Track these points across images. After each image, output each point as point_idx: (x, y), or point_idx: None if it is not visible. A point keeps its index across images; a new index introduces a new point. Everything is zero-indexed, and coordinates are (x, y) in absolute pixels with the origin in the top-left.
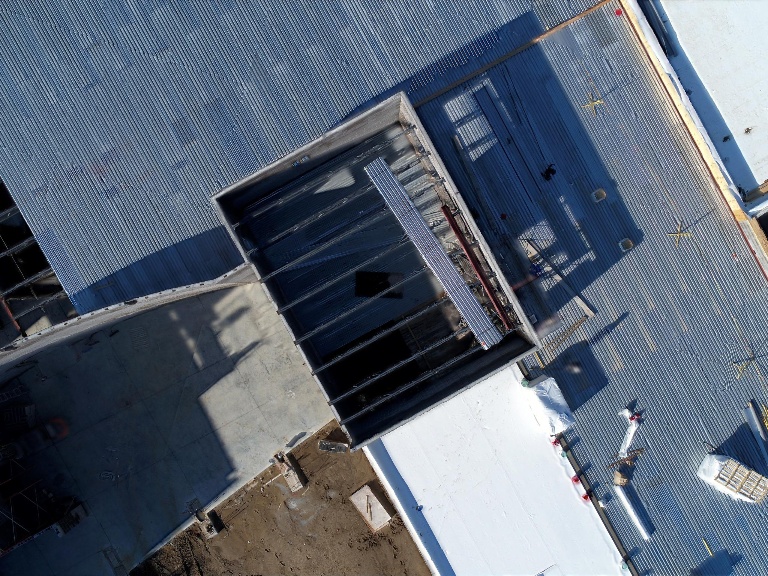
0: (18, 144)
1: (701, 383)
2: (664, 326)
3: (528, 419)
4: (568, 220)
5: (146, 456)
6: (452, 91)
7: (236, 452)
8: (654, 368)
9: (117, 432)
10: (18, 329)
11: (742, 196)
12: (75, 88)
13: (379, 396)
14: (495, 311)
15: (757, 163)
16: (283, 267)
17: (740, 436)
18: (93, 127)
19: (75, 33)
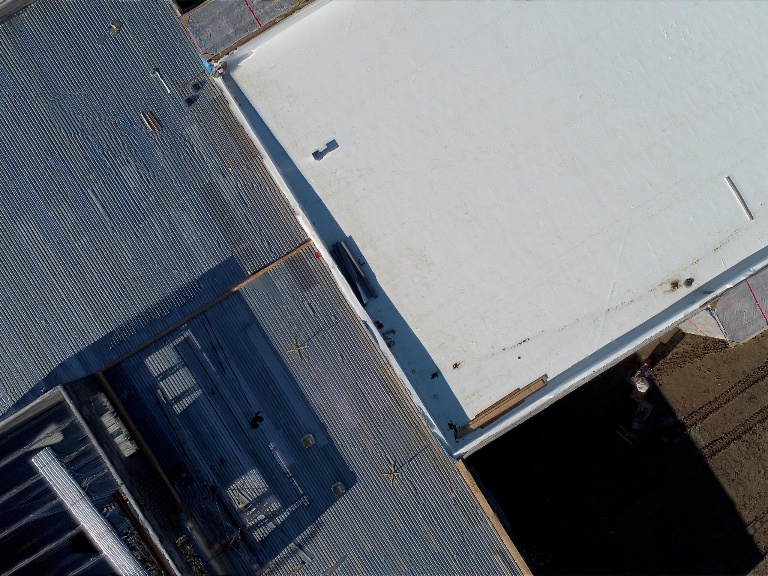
0: None
1: None
2: (383, 567)
3: None
4: (279, 467)
5: None
6: (152, 345)
7: None
8: None
9: None
10: None
11: (454, 432)
12: None
13: None
14: None
15: (467, 398)
16: None
17: None
18: None
19: None
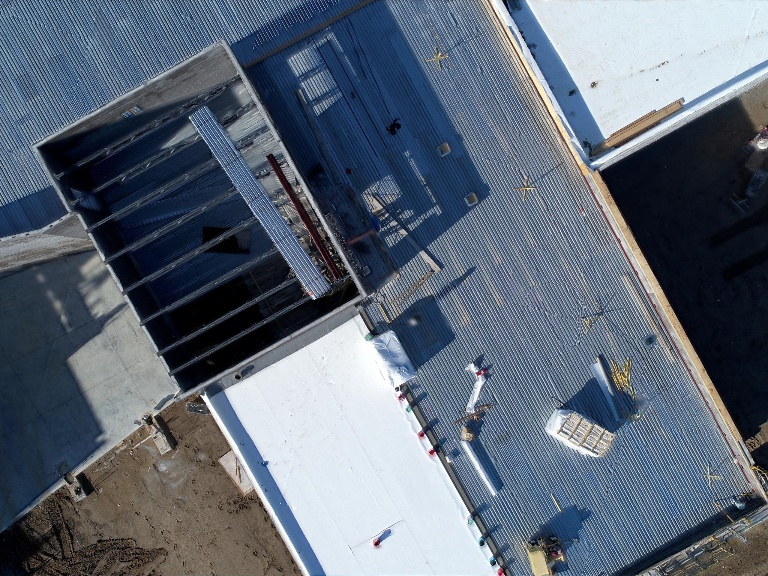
0: None
1: (549, 338)
2: (511, 281)
3: (374, 374)
4: (413, 175)
5: (14, 419)
6: (296, 45)
7: (104, 414)
8: (501, 323)
9: None
10: None
11: (588, 150)
12: None
13: (208, 347)
14: (323, 261)
15: (603, 117)
16: (109, 217)
17: (588, 391)
18: None
19: None
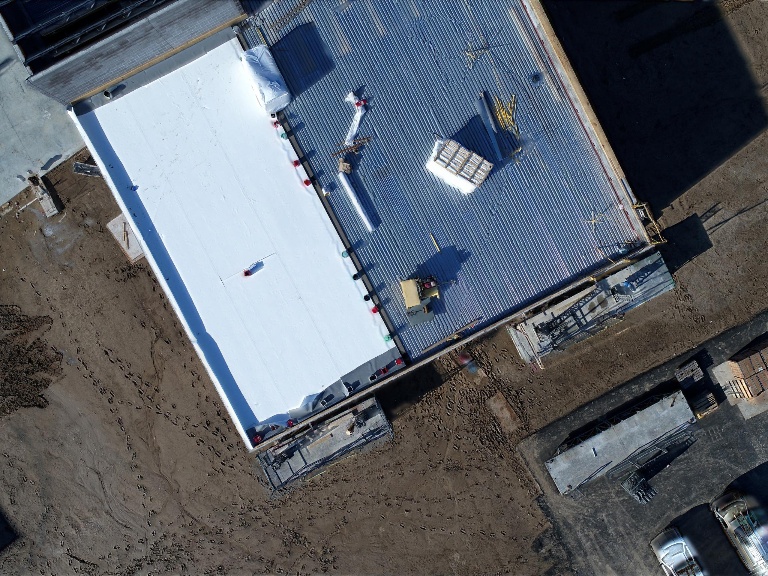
0: None
1: (433, 72)
2: (395, 10)
3: (250, 100)
4: None
5: None
6: None
7: None
8: (384, 54)
9: None
10: None
11: None
12: None
13: None
14: None
15: None
16: None
17: (472, 129)
18: None
19: None
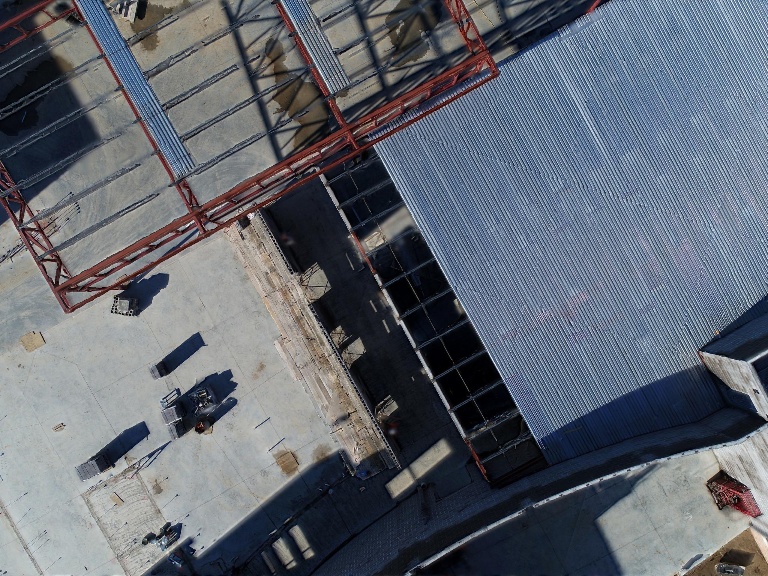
0: (488, 288)
1: None
2: None
3: None
4: None
5: None
6: None
7: (632, 574)
8: None
9: (513, 554)
10: (484, 473)
11: None
12: (545, 231)
13: None
14: None
15: None
16: None
17: None
18: (562, 270)
19: (546, 176)
